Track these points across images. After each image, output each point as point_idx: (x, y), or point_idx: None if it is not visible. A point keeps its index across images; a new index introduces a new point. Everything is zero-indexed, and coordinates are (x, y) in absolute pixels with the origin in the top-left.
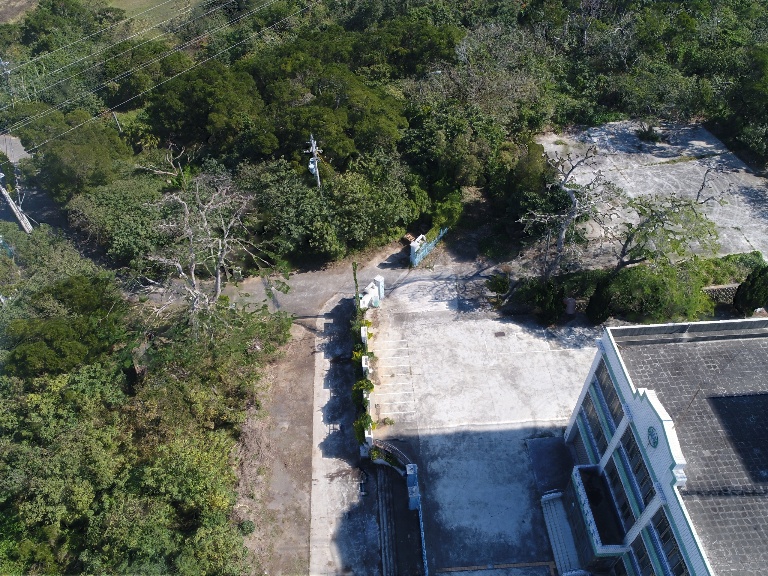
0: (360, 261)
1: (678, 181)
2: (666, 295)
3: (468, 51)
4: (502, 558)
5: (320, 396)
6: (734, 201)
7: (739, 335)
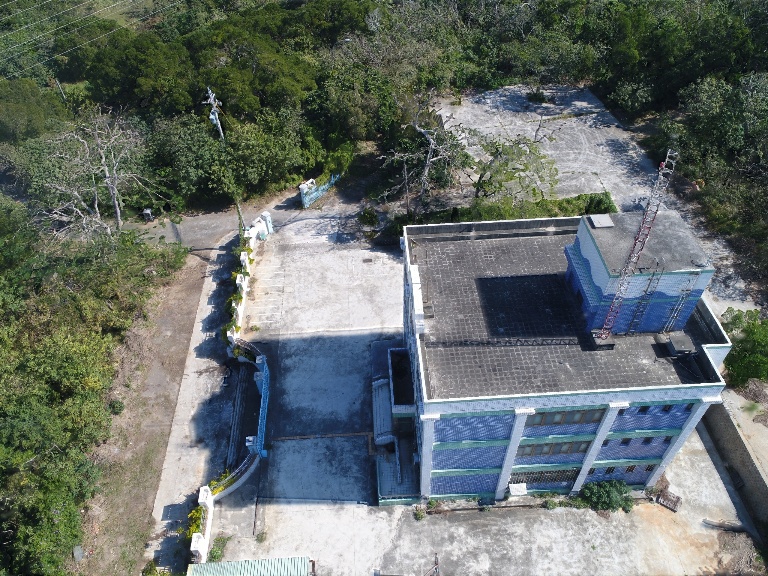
0: (259, 204)
1: (554, 135)
2: (499, 219)
3: (384, 24)
4: (330, 430)
5: (203, 311)
6: (599, 151)
7: (518, 233)
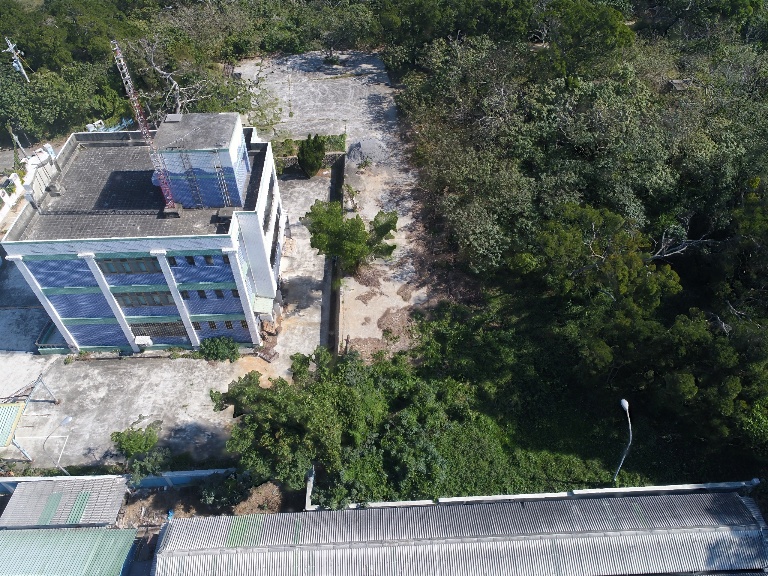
0: (59, 142)
1: (328, 90)
2: None
3: None
4: (29, 303)
5: None
6: (358, 103)
7: None
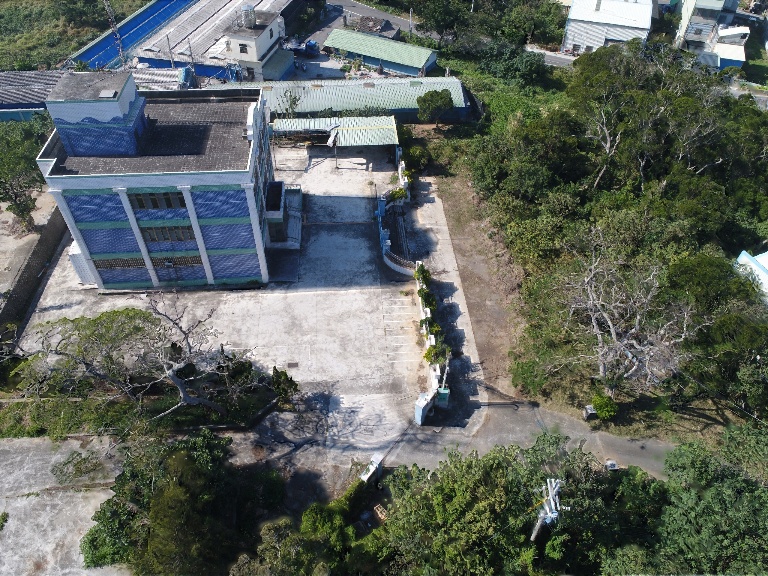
0: None
1: None
2: (133, 309)
3: None
4: (333, 226)
5: (466, 323)
6: None
7: None
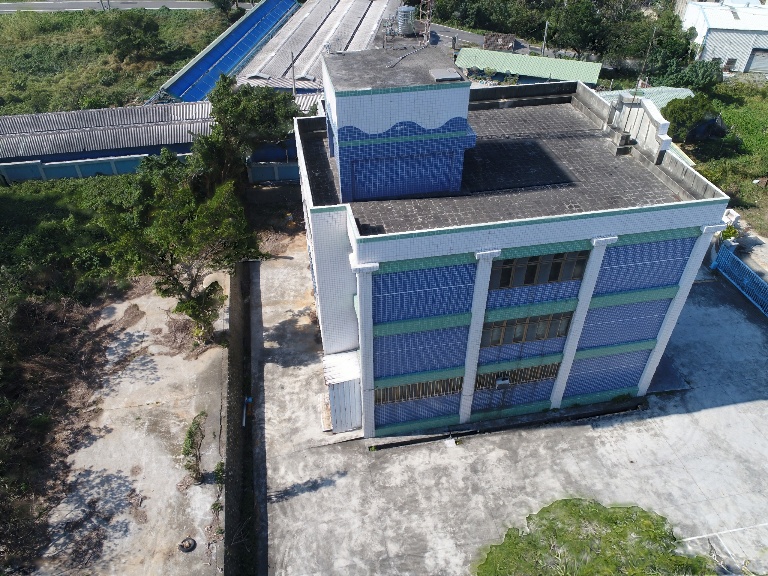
0: None
1: None
2: (580, 500)
3: None
4: None
5: None
6: None
7: None
